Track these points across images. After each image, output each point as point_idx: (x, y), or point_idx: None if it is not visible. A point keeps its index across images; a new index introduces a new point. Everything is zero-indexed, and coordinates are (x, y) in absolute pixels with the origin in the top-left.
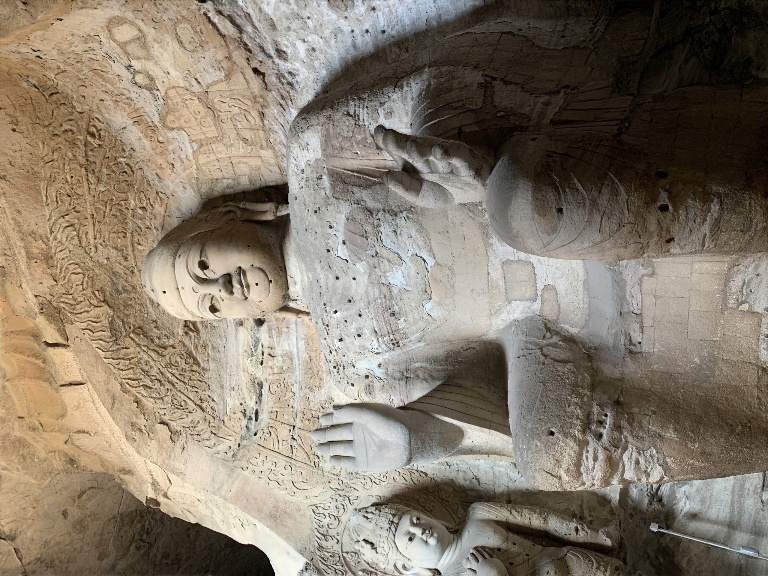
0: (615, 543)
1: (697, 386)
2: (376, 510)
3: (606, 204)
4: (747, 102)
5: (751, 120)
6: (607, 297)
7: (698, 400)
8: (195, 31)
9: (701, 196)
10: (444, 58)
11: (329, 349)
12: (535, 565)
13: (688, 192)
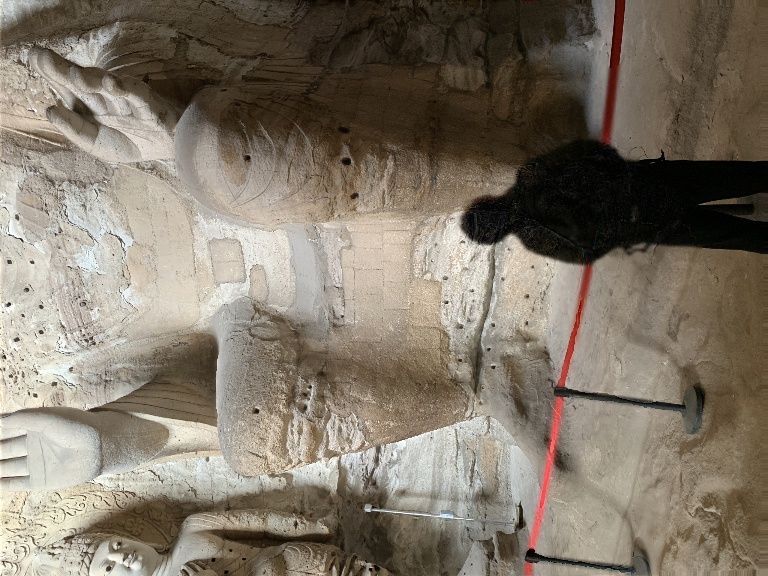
0: (332, 530)
1: (392, 352)
2: (66, 543)
3: (293, 154)
4: (417, 80)
5: (420, 95)
6: (312, 273)
7: (392, 365)
8: None
9: (378, 152)
10: (138, 14)
11: (2, 353)
12: (251, 568)
13: (367, 148)
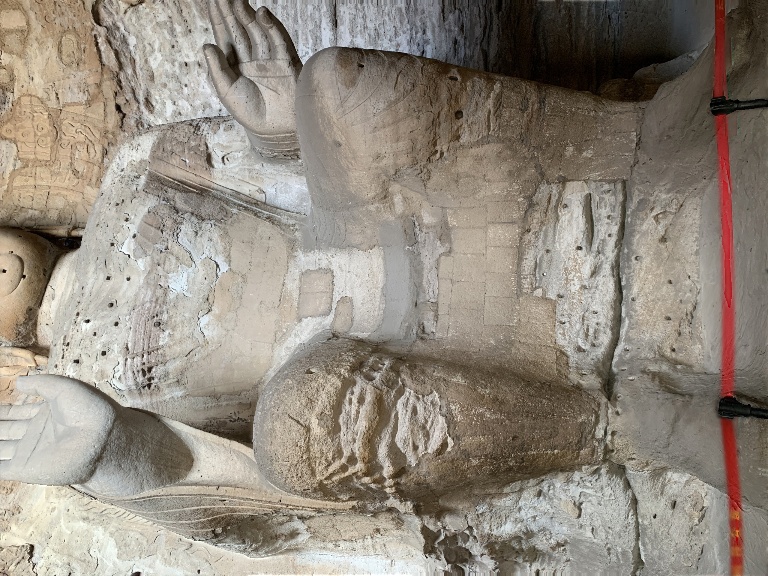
0: None
1: (492, 359)
2: None
3: (403, 67)
4: None
5: None
6: (404, 292)
7: (492, 366)
8: (79, 48)
9: (485, 78)
10: None
11: None
12: None
13: (475, 75)
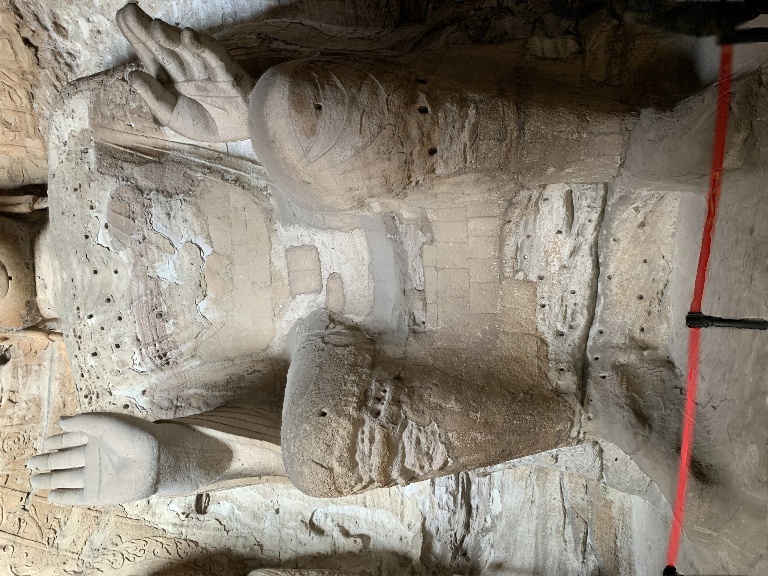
0: None
1: (480, 359)
2: None
3: (366, 102)
4: (502, 50)
5: (505, 62)
6: (391, 276)
7: (481, 372)
8: None
9: (458, 101)
10: (231, 32)
11: (80, 371)
12: None
13: (446, 97)
